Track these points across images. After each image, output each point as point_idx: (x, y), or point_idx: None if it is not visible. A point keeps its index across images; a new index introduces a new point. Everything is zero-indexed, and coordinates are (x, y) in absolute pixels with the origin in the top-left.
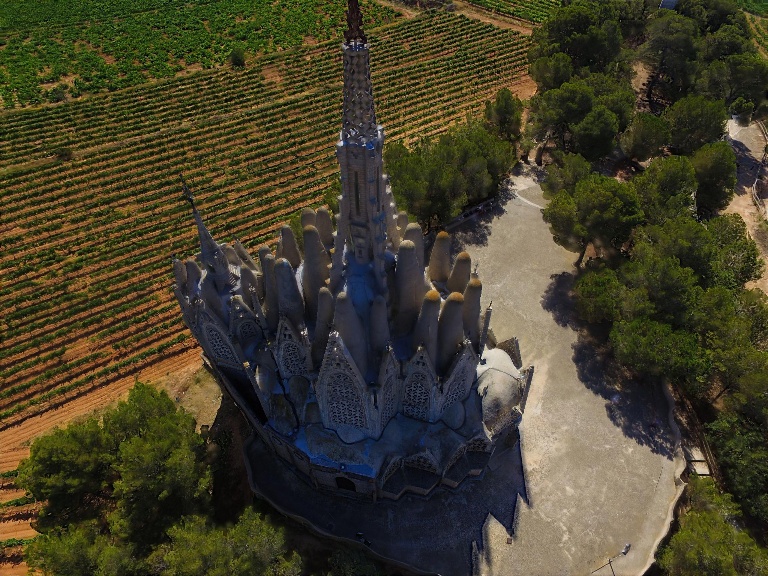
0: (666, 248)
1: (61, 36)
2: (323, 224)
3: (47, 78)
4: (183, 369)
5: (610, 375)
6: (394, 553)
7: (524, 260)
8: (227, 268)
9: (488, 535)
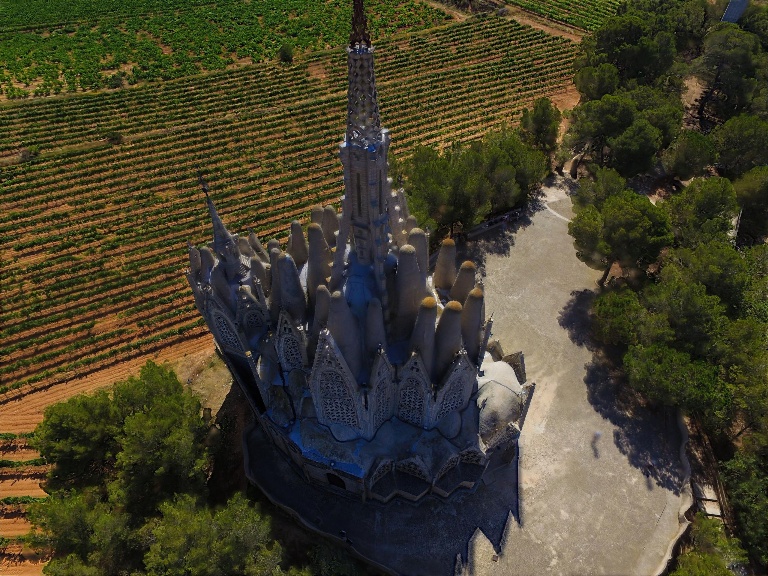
0: (696, 273)
1: (125, 26)
2: (329, 223)
3: (108, 65)
4: (200, 352)
5: (622, 400)
6: (377, 555)
7: (545, 274)
8: (238, 258)
9: (474, 549)
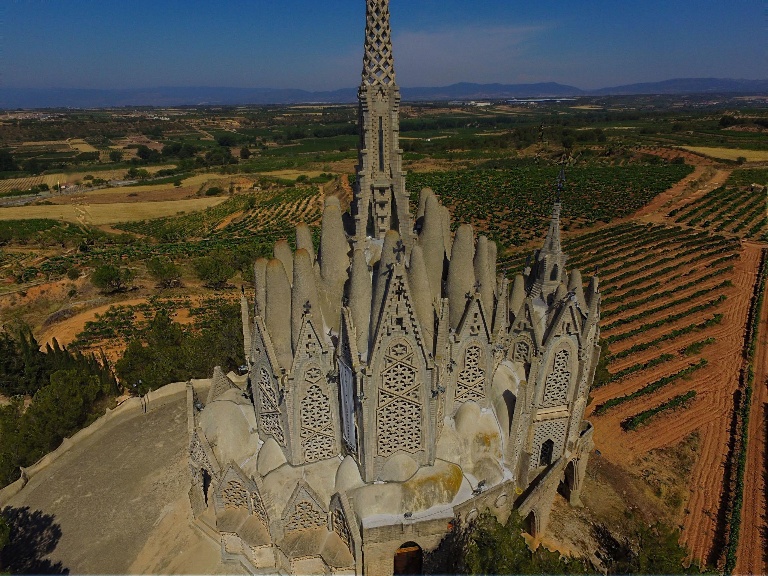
0: None
1: None
2: None
3: None
4: None
5: None
6: None
7: None
8: (537, 278)
9: None
